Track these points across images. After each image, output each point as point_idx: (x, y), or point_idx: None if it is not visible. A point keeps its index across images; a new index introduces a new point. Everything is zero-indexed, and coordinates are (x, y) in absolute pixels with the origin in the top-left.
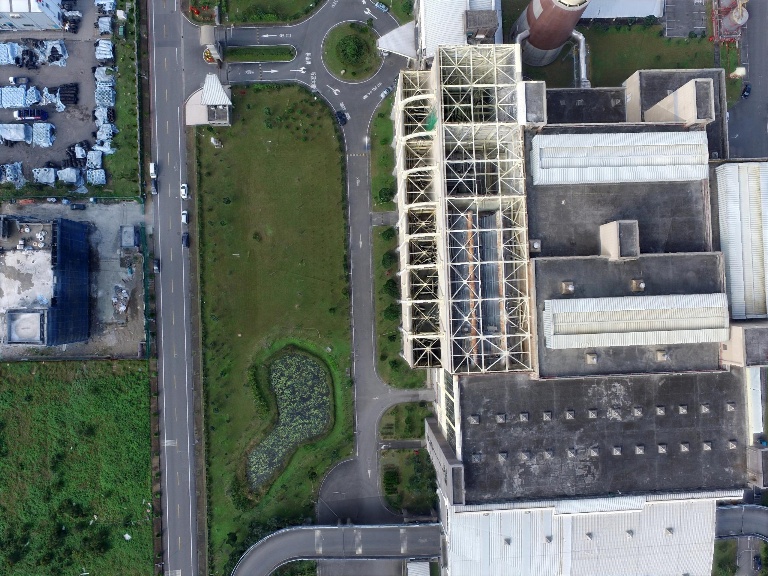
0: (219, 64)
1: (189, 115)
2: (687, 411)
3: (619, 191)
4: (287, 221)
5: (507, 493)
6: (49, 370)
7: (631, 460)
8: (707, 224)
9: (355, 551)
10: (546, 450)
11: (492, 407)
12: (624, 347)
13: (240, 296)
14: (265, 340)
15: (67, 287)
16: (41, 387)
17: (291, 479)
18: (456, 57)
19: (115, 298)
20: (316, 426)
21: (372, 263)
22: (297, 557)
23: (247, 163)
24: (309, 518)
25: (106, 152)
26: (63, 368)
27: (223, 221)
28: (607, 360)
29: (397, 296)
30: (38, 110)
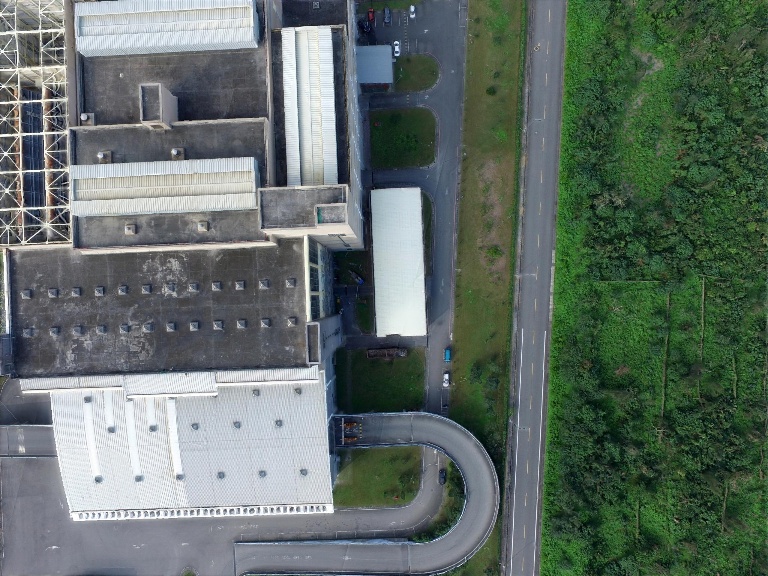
0: None
1: None
2: (244, 287)
3: (178, 62)
4: None
5: (60, 368)
6: None
7: (187, 337)
8: None
9: (18, 450)
10: (98, 325)
11: (45, 282)
12: (166, 218)
13: None
14: None
15: None
16: None
17: None
18: None
19: None
20: None
21: None
22: None
23: None
24: None
25: None
26: None
27: None
28: (148, 231)
29: None
30: None
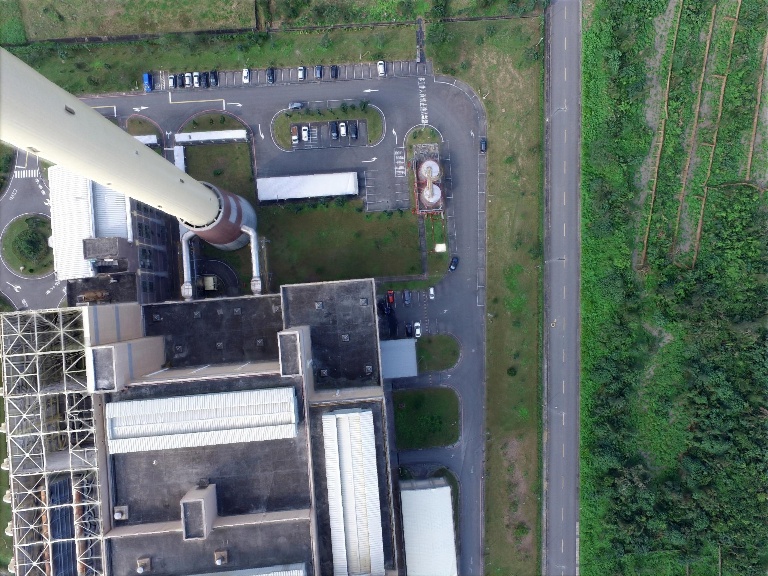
0: None
1: None
2: None
3: (215, 447)
4: None
5: None
6: None
7: None
8: None
9: None
10: None
11: None
12: None
13: None
14: None
15: None
16: None
17: None
18: (19, 324)
19: None
20: None
21: None
22: None
23: None
24: None
25: None
26: None
27: None
28: None
29: None
30: None
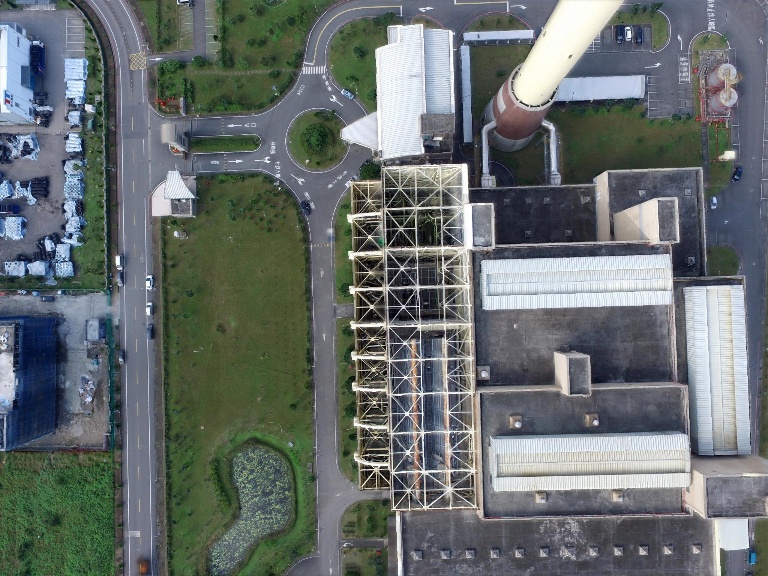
0: (184, 155)
1: (155, 206)
2: (648, 552)
3: (576, 314)
4: (250, 313)
5: None
6: (18, 459)
7: None
8: (672, 351)
9: None
10: None
11: (436, 542)
12: None
13: (203, 388)
14: (227, 433)
15: (30, 385)
16: (10, 476)
17: (252, 575)
18: (400, 179)
19: (82, 389)
20: (278, 521)
21: (335, 356)
22: None
23: (211, 254)
24: None
25: (74, 244)
26: (31, 458)
27: (186, 314)
28: (558, 499)
29: None
30: (9, 205)
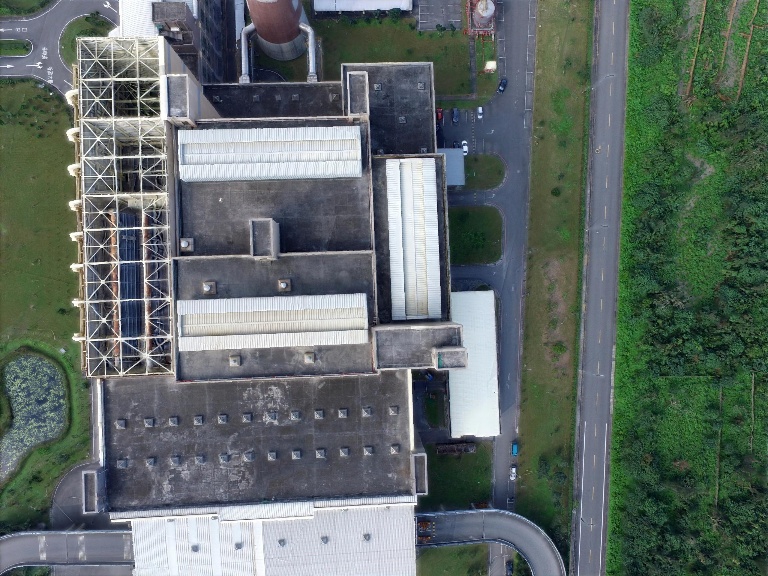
0: None
1: None
2: (347, 415)
3: (280, 188)
4: (22, 220)
5: (156, 500)
6: None
7: (288, 465)
8: (370, 222)
9: (79, 557)
10: (196, 455)
11: (140, 411)
12: (271, 349)
13: None
14: None
15: None
16: None
17: (24, 483)
18: (96, 50)
19: None
20: (52, 429)
21: None
22: (21, 563)
23: None
24: (42, 523)
25: None
26: None
27: None
28: (253, 363)
29: None
30: None
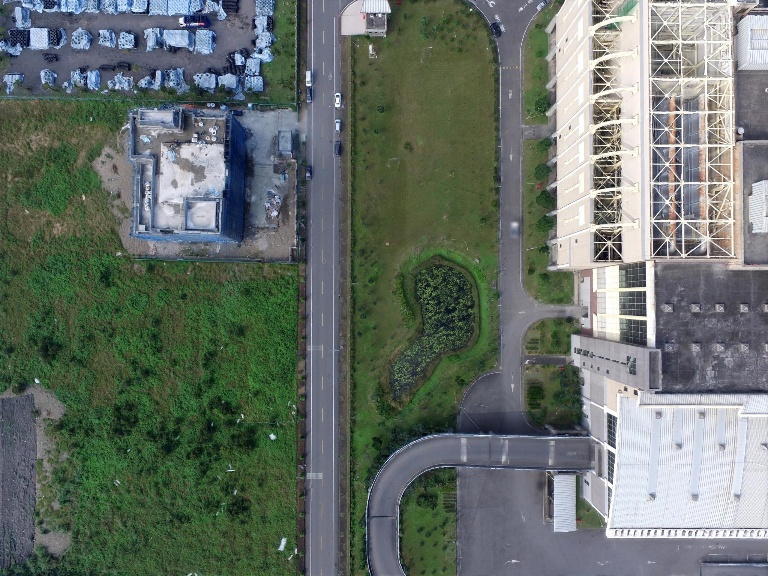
0: None
1: (345, 25)
2: None
3: None
4: (438, 132)
5: (699, 385)
6: (203, 270)
7: None
8: None
9: (501, 461)
10: (742, 342)
11: (686, 296)
12: None
13: (389, 205)
14: (413, 249)
15: (233, 183)
16: (195, 286)
17: (434, 389)
18: None
19: (268, 203)
20: (460, 338)
21: (522, 177)
22: (442, 464)
23: (400, 74)
24: (451, 429)
25: (264, 60)
26: (216, 269)
27: (377, 129)
28: None
29: (552, 207)
30: (203, 16)
